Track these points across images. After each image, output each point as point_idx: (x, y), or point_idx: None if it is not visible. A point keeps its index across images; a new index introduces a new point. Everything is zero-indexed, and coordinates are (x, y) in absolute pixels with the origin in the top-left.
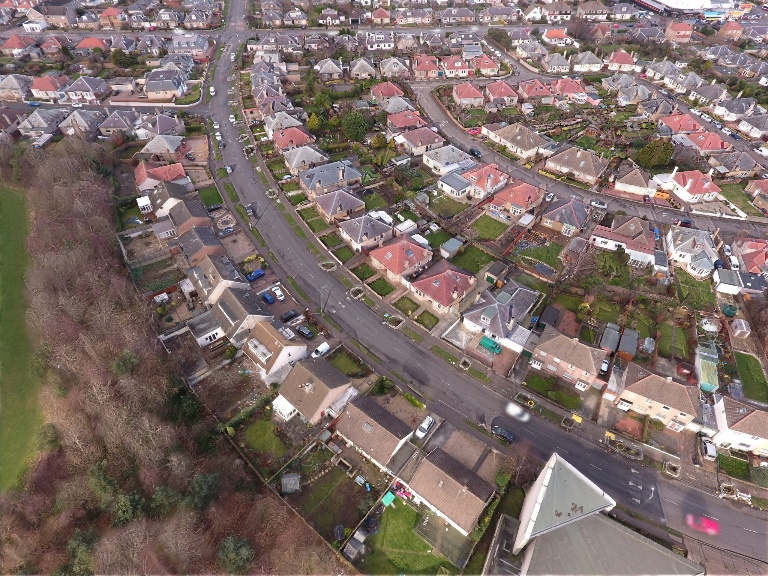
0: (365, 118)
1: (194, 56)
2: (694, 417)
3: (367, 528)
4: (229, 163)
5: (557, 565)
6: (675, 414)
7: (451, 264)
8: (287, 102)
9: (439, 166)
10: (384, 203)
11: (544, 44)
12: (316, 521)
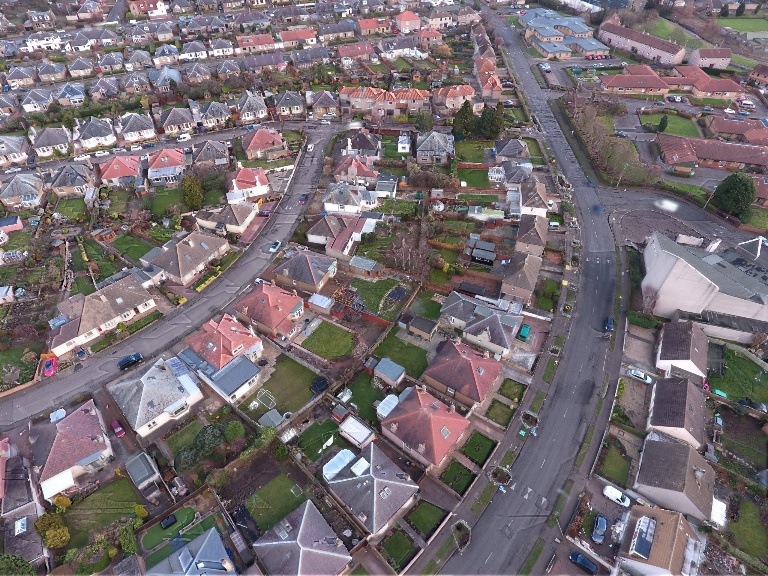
0: None
1: None
2: None
3: (754, 404)
4: None
5: None
6: None
7: (436, 362)
8: None
9: None
10: (279, 481)
11: None
12: None
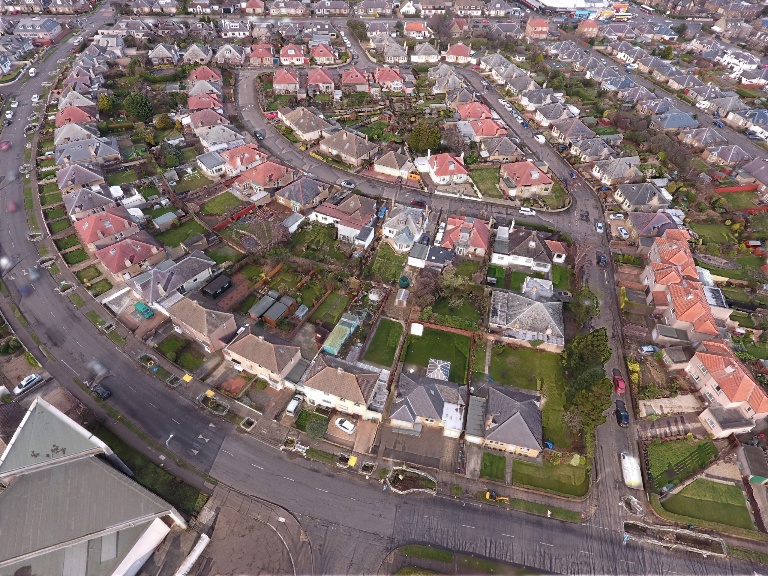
0: (164, 100)
1: (40, 39)
2: (277, 374)
3: None
4: (3, 140)
5: (22, 502)
6: (267, 372)
7: (145, 235)
8: (94, 83)
9: (206, 146)
10: (134, 179)
11: (401, 36)
12: None
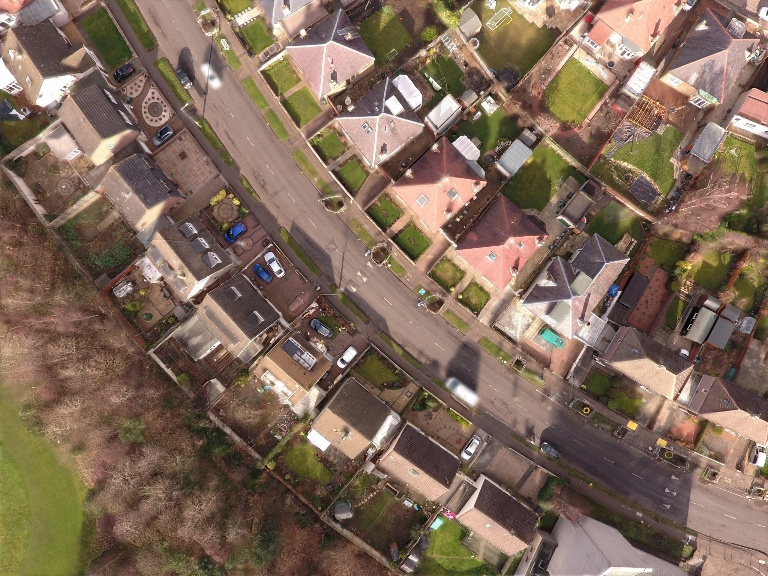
0: None
1: None
2: (761, 444)
3: (419, 551)
4: None
5: None
6: None
7: (513, 210)
8: None
9: None
10: (404, 37)
11: None
12: (372, 538)
